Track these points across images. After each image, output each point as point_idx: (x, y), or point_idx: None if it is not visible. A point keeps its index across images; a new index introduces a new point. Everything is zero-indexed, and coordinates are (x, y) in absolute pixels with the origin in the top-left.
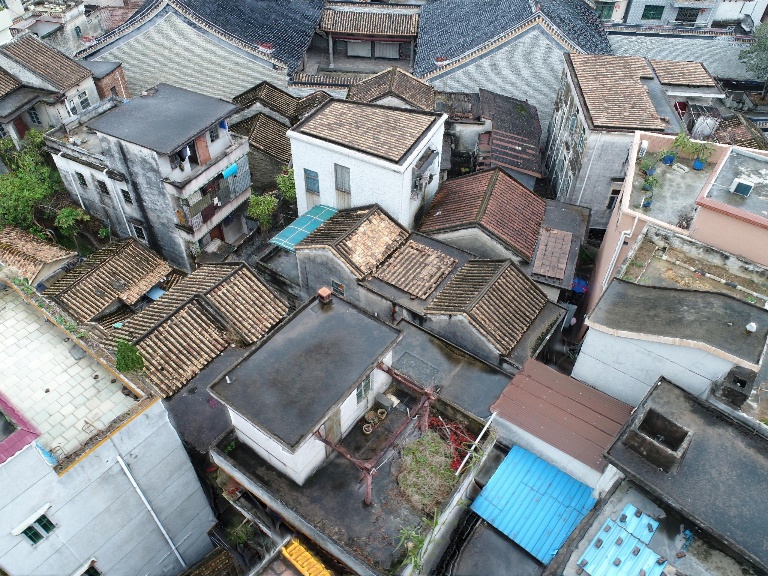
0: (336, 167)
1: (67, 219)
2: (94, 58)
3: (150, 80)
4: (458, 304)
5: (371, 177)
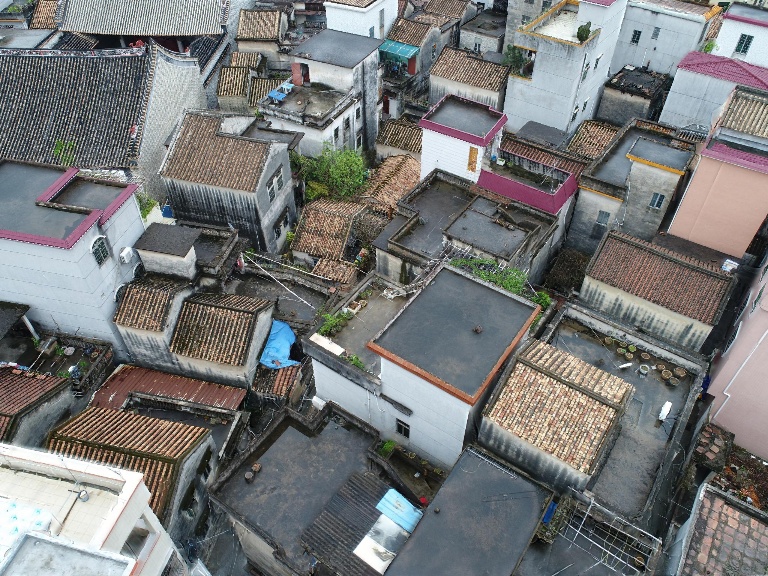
0: (379, 14)
1: (359, 157)
2: (141, 146)
3: (164, 137)
4: (460, 6)
5: (390, 5)
